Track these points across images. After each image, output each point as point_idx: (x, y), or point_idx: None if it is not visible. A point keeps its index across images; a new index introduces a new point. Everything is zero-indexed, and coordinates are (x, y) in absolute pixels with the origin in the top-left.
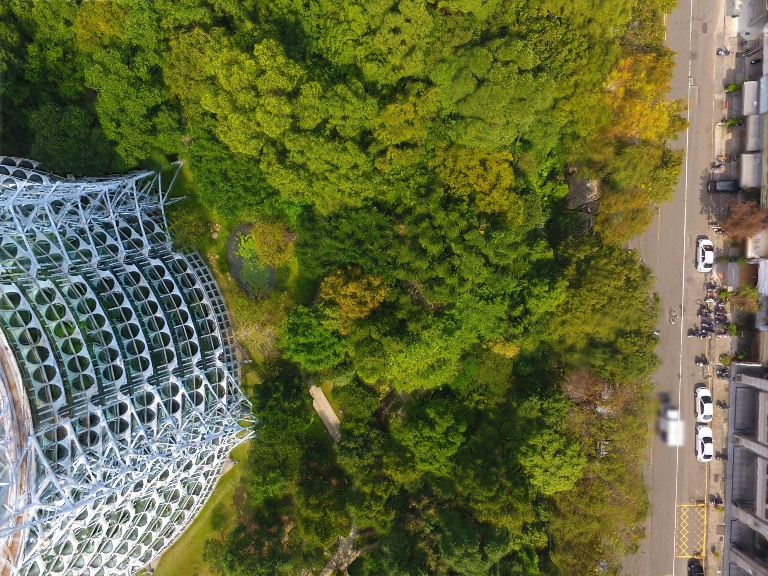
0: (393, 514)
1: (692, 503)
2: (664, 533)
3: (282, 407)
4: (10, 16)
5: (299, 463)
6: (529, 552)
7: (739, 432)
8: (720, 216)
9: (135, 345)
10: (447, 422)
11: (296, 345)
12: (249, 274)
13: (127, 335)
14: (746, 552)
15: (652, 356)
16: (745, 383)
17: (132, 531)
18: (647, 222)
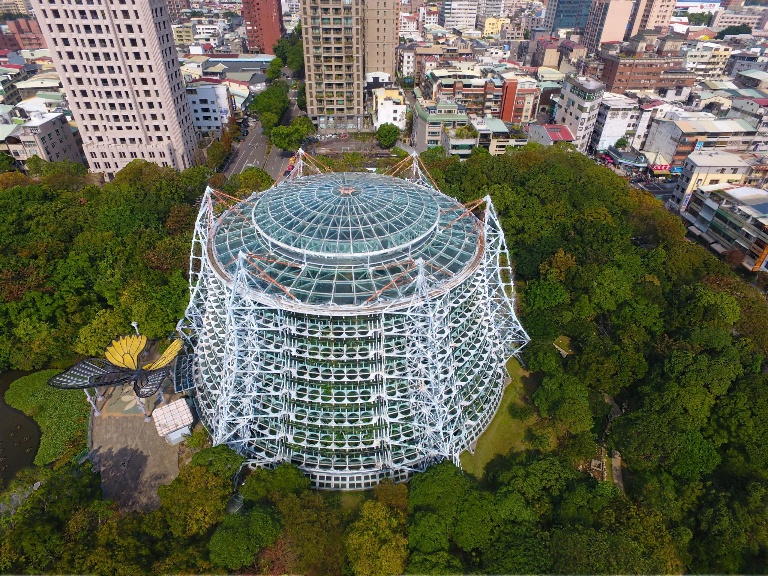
0: None
1: None
2: None
3: None
4: None
5: None
6: None
7: None
8: None
9: None
10: None
11: None
12: None
13: None
14: None
15: None
16: None
17: (479, 356)
18: None
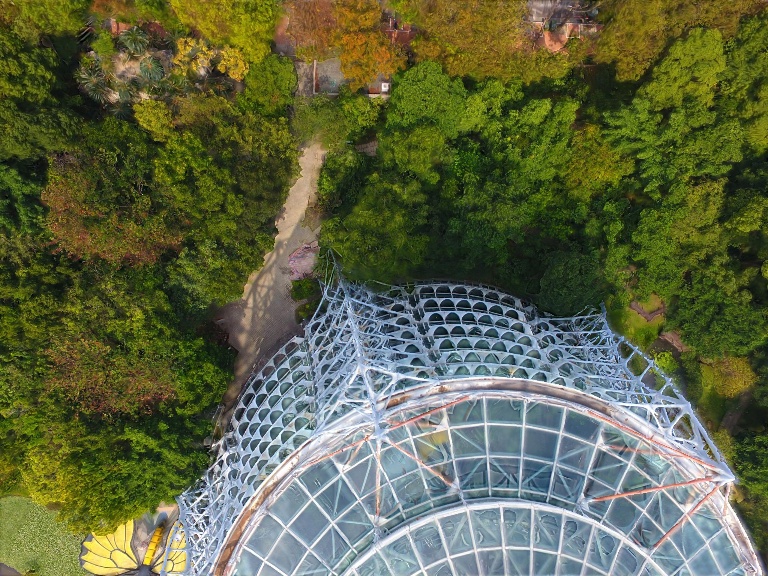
0: None
1: None
2: None
3: None
4: (501, 160)
5: None
6: None
7: None
8: None
9: None
10: None
11: (755, 474)
12: None
13: None
14: None
15: None
16: None
17: None
18: None
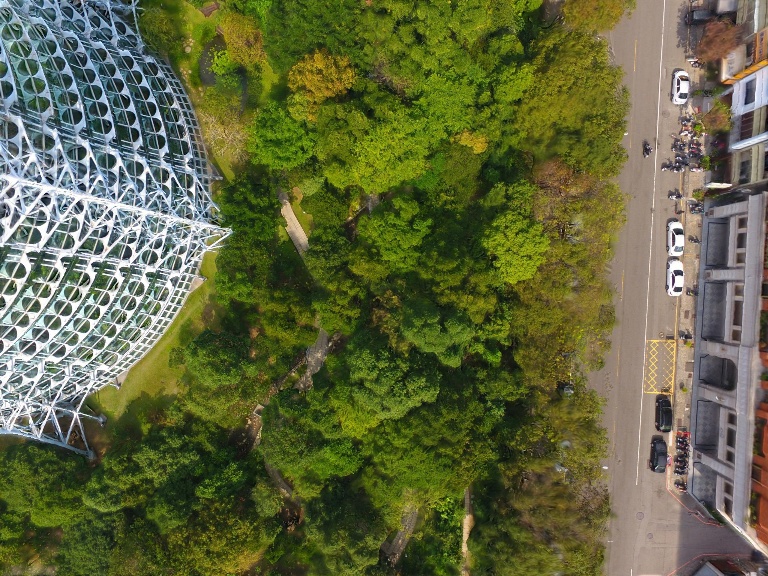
0: (358, 312)
1: (662, 338)
2: (633, 368)
3: (249, 206)
4: None
5: (267, 273)
6: (492, 349)
7: (710, 267)
8: (697, 49)
9: (98, 107)
10: (412, 208)
11: (264, 142)
12: (222, 91)
13: (90, 97)
14: (714, 384)
15: (619, 147)
16: (717, 216)
17: (94, 310)
18: (617, 7)
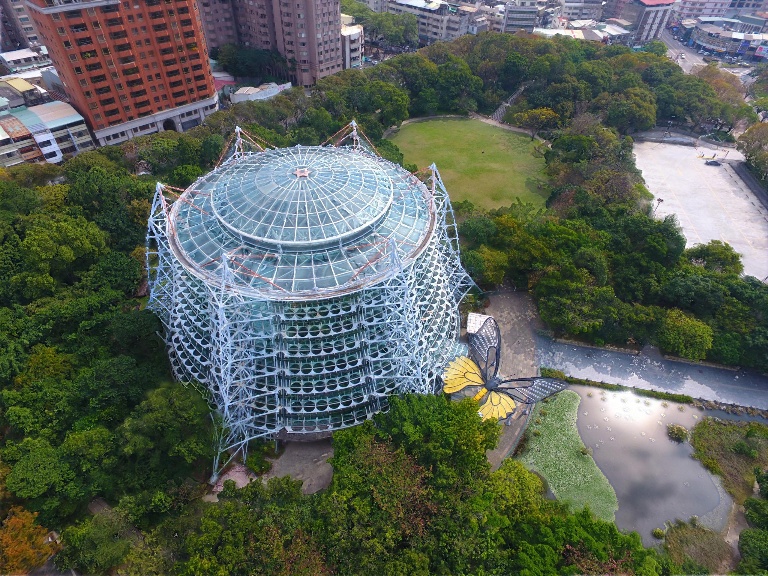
0: None
1: None
2: None
3: None
4: None
5: None
6: None
7: None
8: None
9: None
10: None
11: None
12: None
13: None
14: (176, 130)
15: None
16: None
17: None
18: None
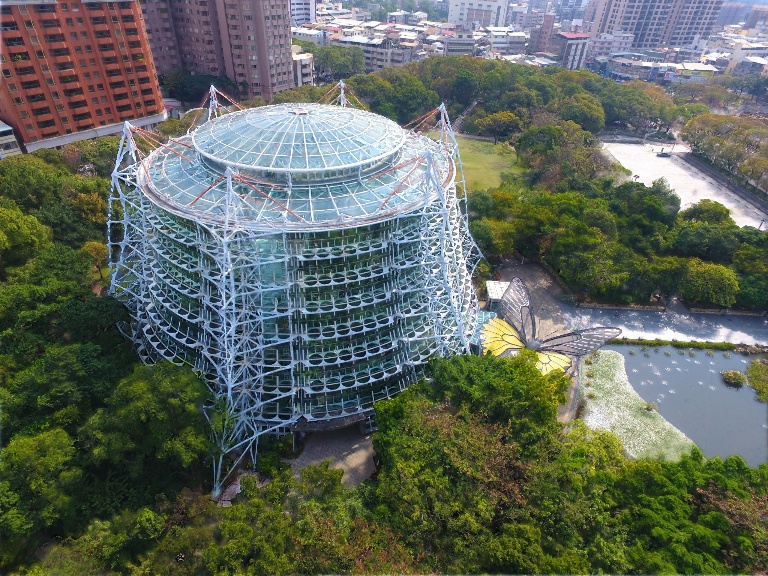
0: None
1: None
2: None
3: None
4: None
5: None
6: None
7: None
8: None
9: None
10: None
11: None
12: None
13: None
14: None
15: None
16: None
17: None
18: None
